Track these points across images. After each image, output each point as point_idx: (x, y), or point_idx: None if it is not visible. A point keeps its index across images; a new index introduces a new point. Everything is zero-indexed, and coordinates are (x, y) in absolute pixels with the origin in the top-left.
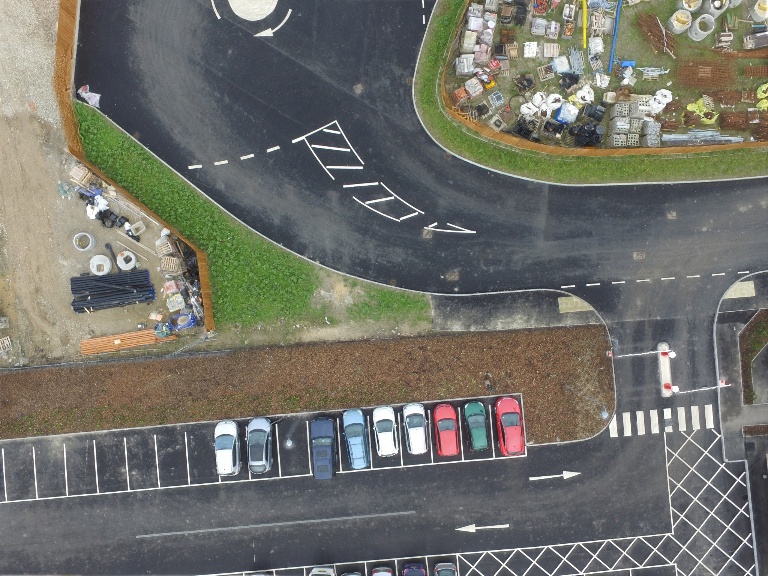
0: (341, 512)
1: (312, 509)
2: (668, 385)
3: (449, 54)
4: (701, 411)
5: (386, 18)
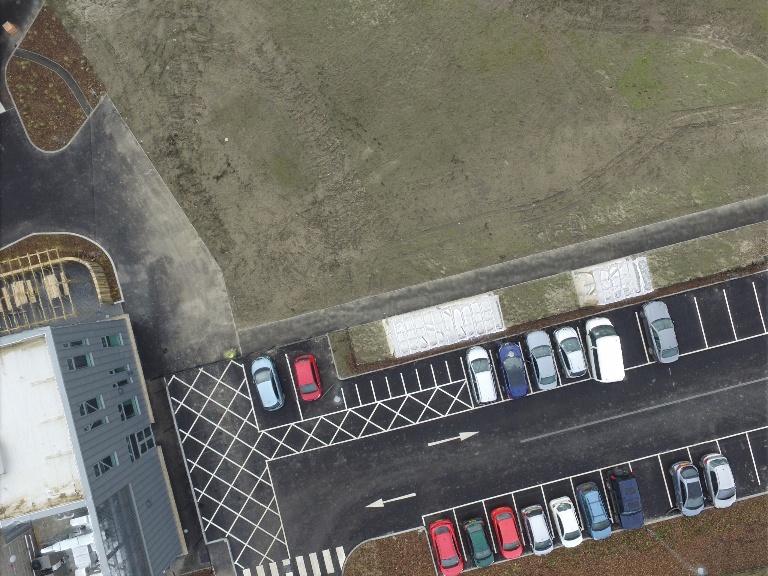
0: (593, 430)
1: (622, 428)
2: None
3: None
4: None
5: None
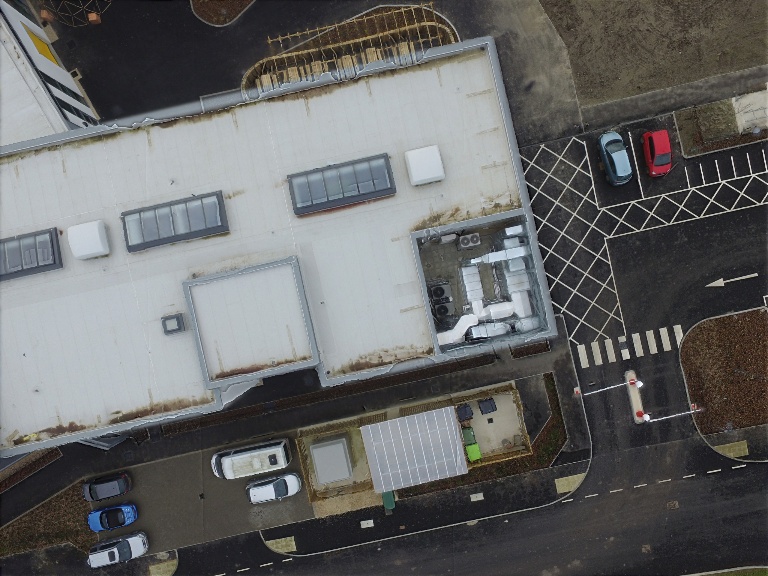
0: None
1: None
2: None
3: None
4: (592, 361)
5: None
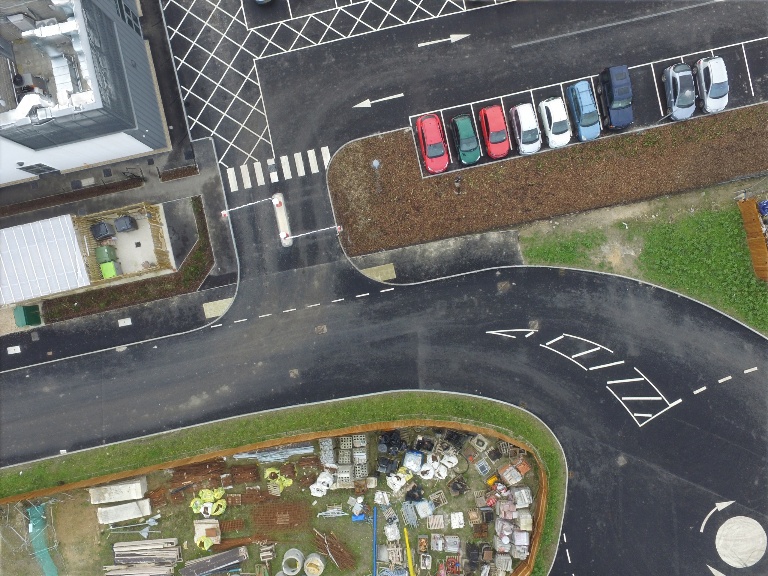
0: (586, 37)
1: (615, 36)
2: (280, 205)
3: (544, 505)
4: (241, 184)
5: (603, 535)
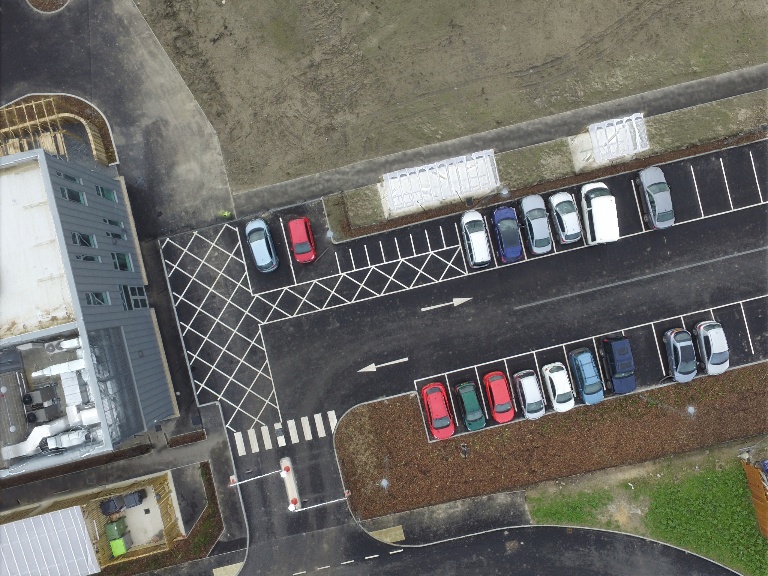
0: (587, 298)
1: (616, 296)
2: None
3: None
4: (249, 448)
5: None
